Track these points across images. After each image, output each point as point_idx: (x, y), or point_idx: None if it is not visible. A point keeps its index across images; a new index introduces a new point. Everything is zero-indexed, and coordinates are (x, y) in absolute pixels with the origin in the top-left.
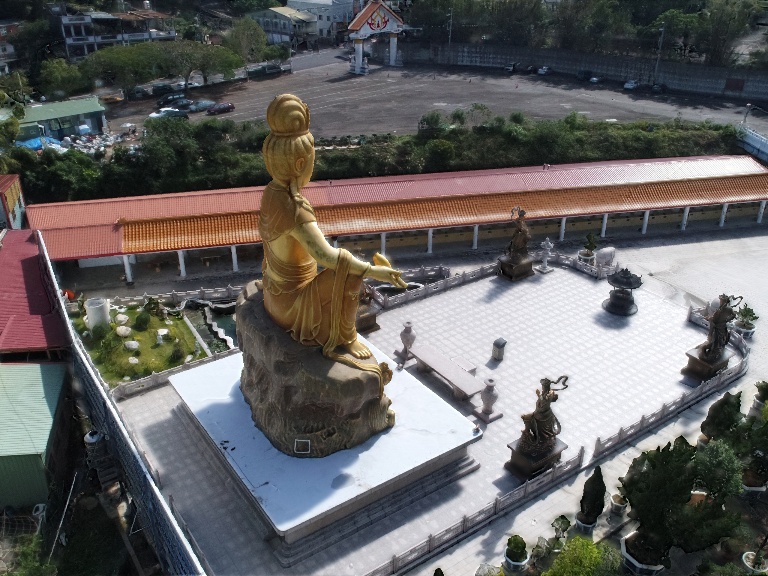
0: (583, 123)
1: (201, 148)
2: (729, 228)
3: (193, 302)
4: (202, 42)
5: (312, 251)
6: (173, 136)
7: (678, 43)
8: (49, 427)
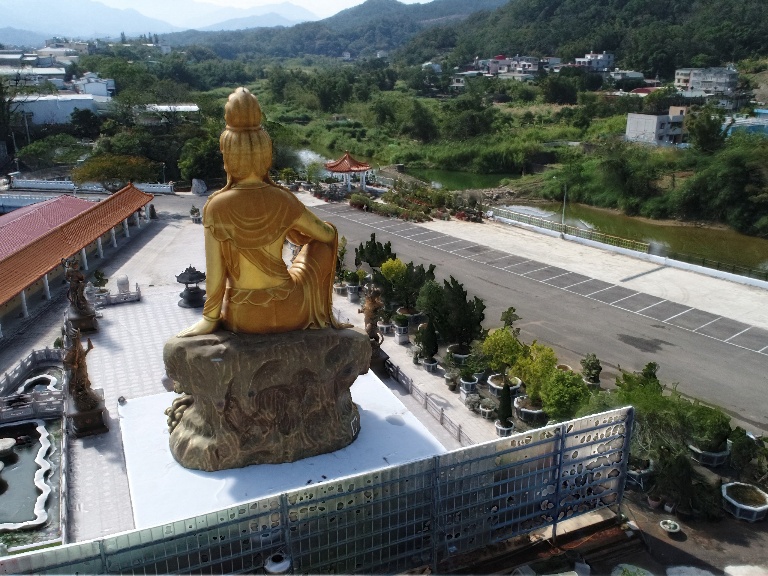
0: None
1: None
2: (123, 246)
3: None
4: None
5: (321, 228)
6: None
7: None
8: None
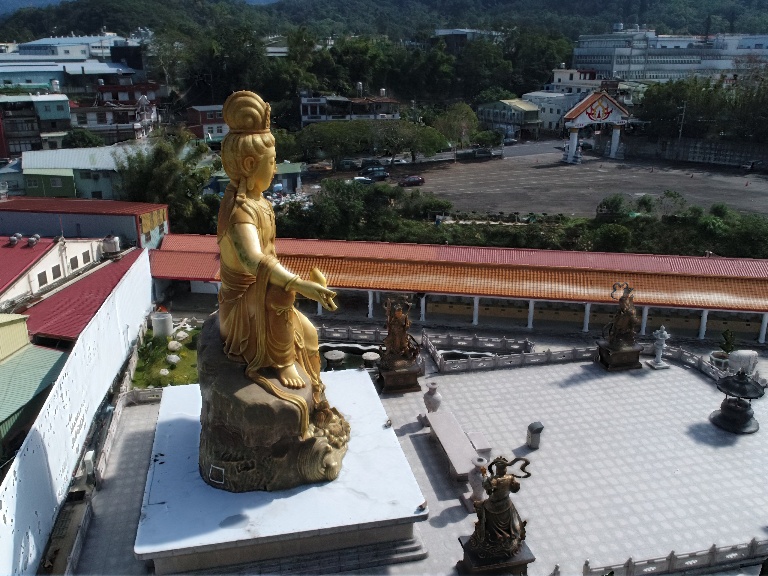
0: None
1: (366, 210)
2: None
3: None
4: (415, 123)
5: (237, 253)
6: (343, 196)
7: None
8: (23, 403)
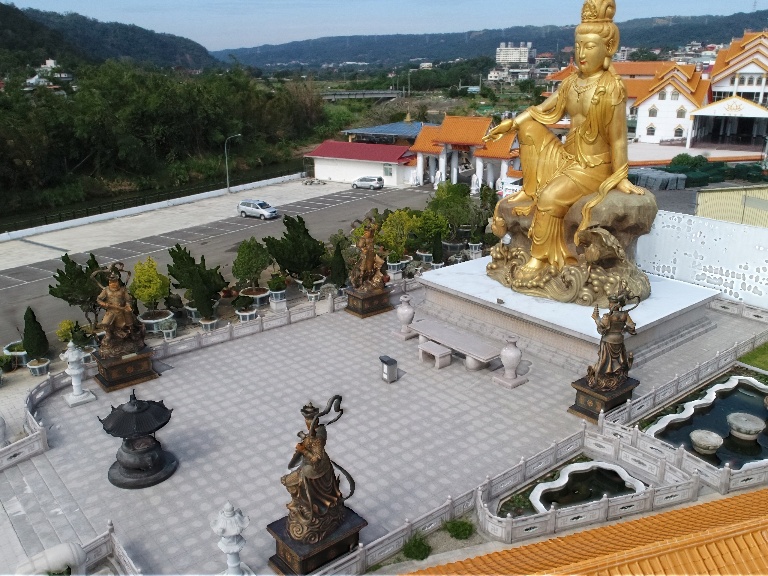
0: None
1: None
2: None
3: None
4: None
5: None
6: None
7: None
8: None
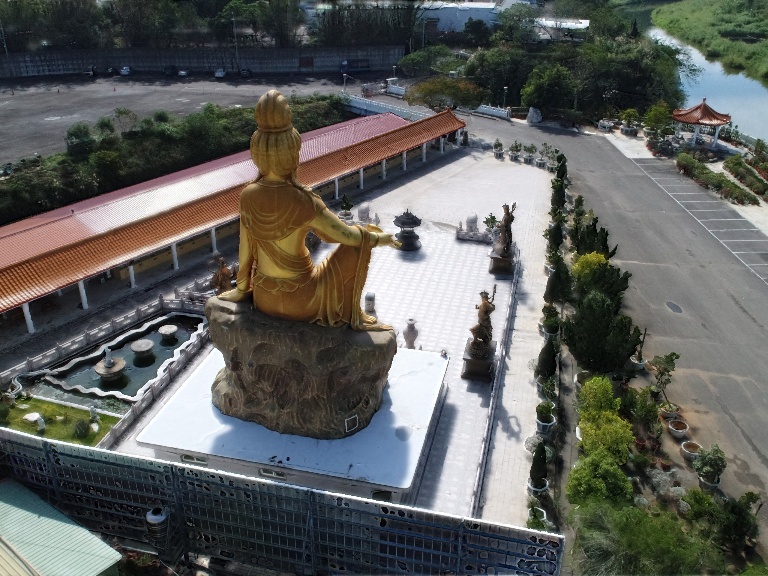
0: (220, 112)
1: None
2: (411, 170)
3: (22, 378)
4: None
5: (338, 234)
6: None
7: (248, 31)
8: (91, 536)
